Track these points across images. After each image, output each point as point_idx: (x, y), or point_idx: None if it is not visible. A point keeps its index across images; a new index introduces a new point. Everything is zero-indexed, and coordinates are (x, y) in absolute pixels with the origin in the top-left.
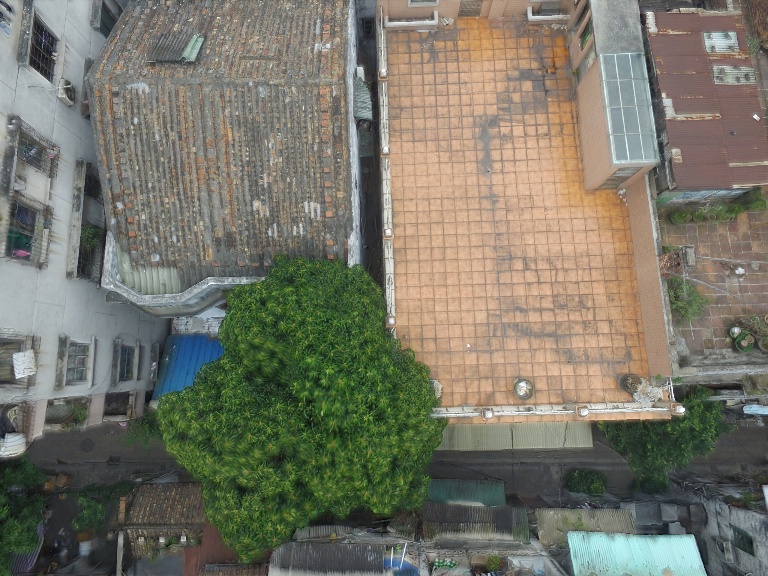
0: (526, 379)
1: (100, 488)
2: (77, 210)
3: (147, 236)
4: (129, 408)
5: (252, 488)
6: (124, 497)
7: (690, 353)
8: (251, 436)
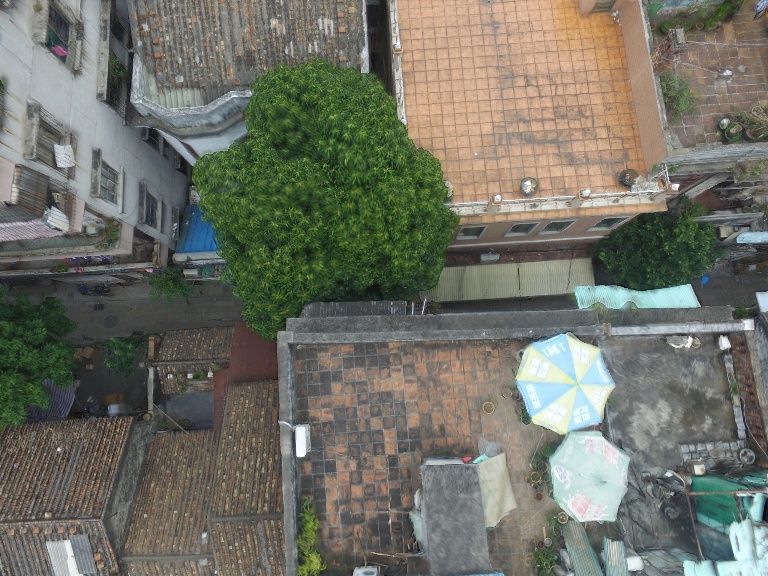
0: None
1: (128, 340)
2: (104, 40)
3: (171, 58)
4: (154, 255)
5: (282, 243)
6: (153, 337)
7: (683, 147)
8: (282, 176)
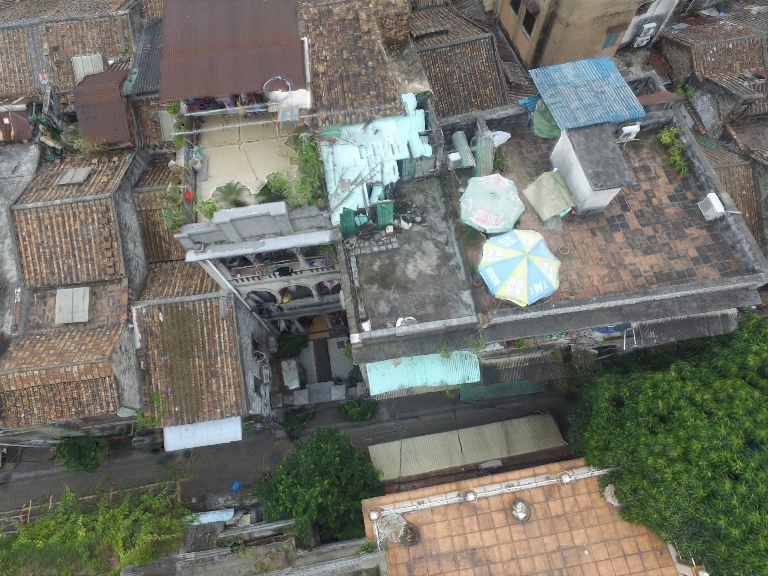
0: (516, 521)
1: None
2: None
3: None
4: None
5: None
6: None
7: None
8: None
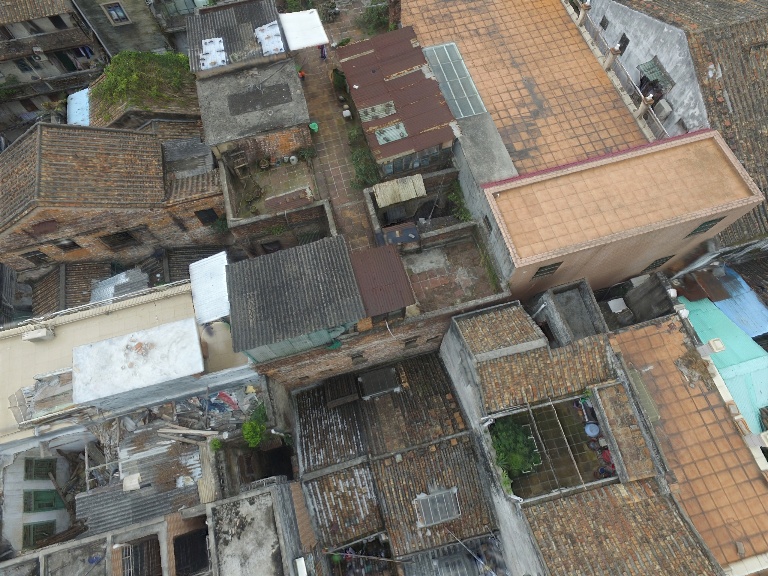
0: None
1: None
2: None
3: None
4: None
5: None
6: None
7: (361, 1)
8: None
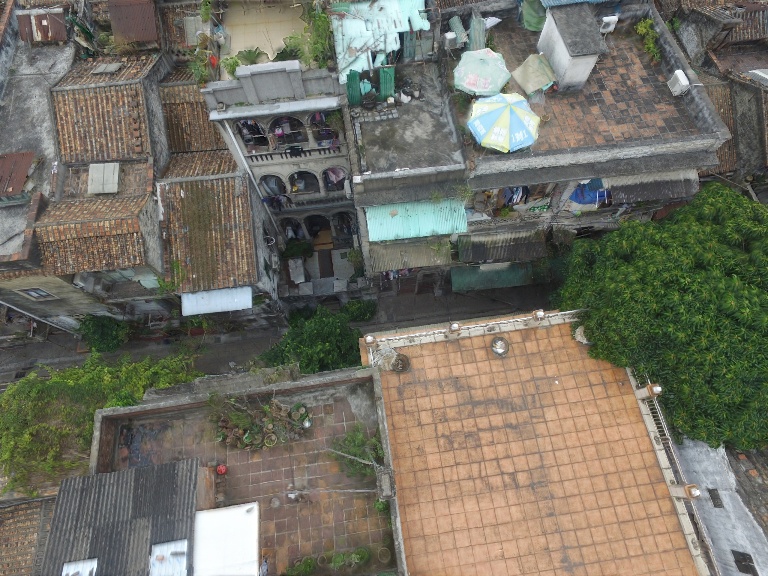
0: (496, 357)
1: None
2: None
3: None
4: None
5: None
6: None
7: (347, 398)
8: None
